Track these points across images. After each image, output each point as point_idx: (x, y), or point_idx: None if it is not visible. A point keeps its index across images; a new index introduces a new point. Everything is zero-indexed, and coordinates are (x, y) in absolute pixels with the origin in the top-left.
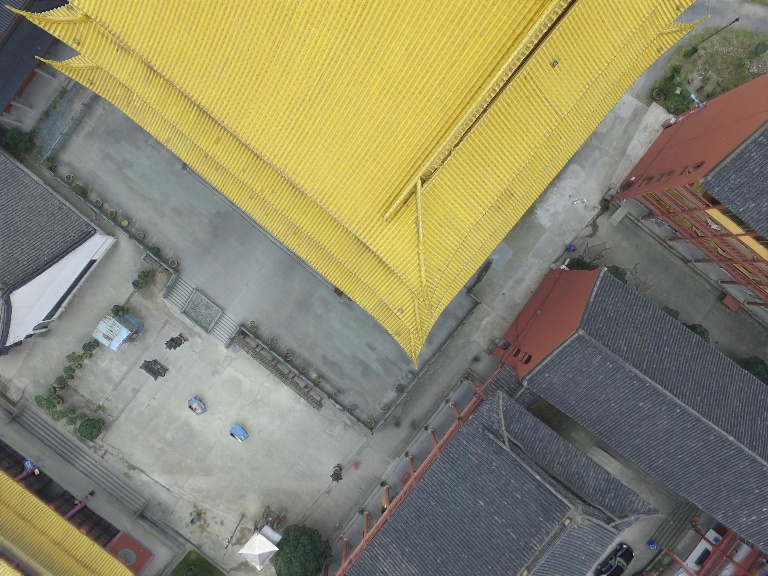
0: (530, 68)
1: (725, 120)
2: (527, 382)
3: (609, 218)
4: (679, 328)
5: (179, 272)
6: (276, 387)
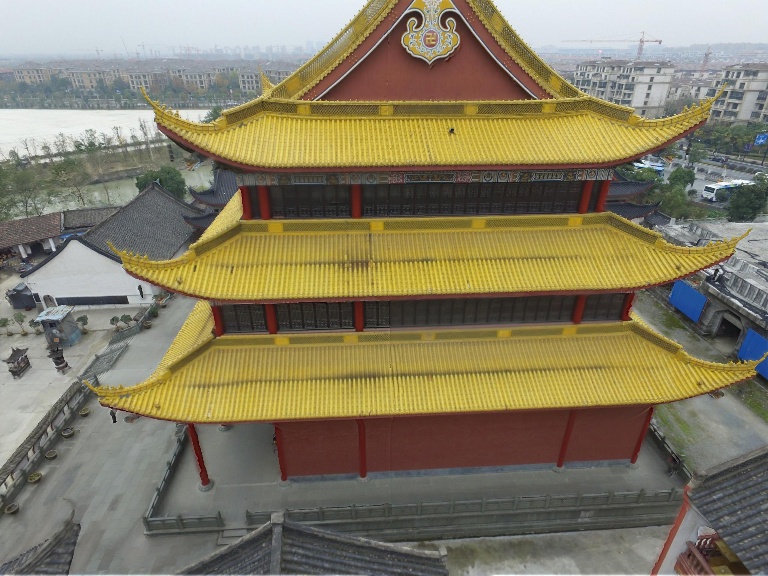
0: (428, 124)
1: None
2: None
3: None
4: None
5: (141, 332)
6: None
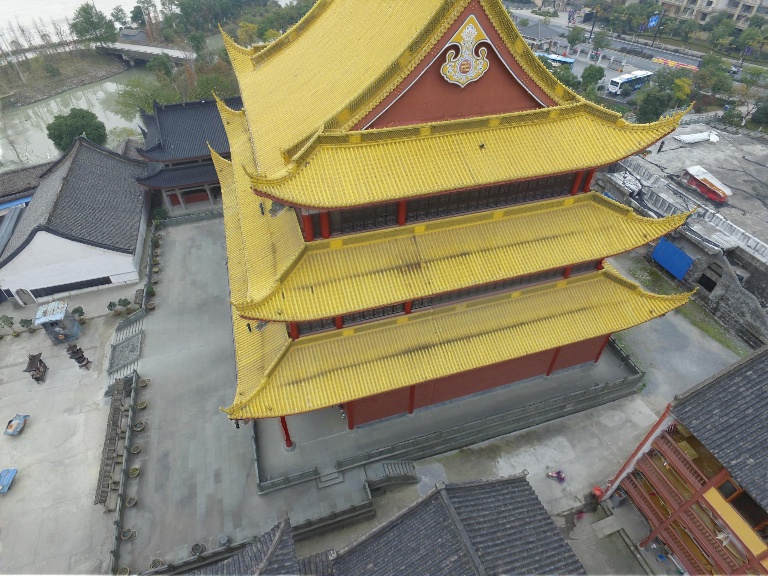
0: (460, 139)
1: None
2: None
3: (593, 522)
4: None
5: (147, 314)
6: (94, 462)
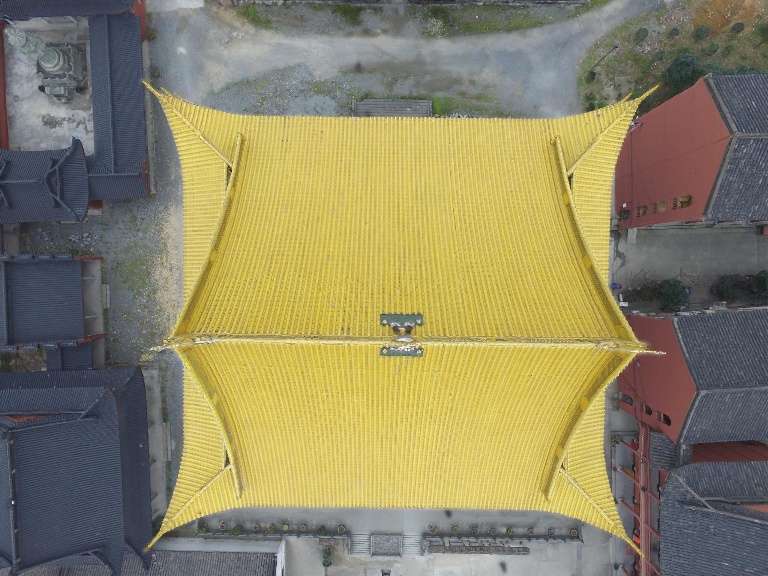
0: None
1: (677, 146)
2: (684, 444)
3: (626, 241)
4: (764, 316)
5: (349, 531)
6: (480, 556)
